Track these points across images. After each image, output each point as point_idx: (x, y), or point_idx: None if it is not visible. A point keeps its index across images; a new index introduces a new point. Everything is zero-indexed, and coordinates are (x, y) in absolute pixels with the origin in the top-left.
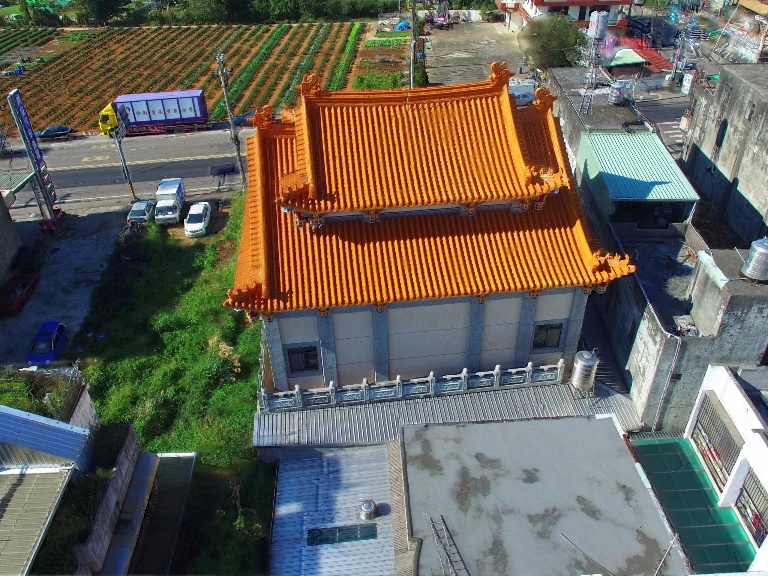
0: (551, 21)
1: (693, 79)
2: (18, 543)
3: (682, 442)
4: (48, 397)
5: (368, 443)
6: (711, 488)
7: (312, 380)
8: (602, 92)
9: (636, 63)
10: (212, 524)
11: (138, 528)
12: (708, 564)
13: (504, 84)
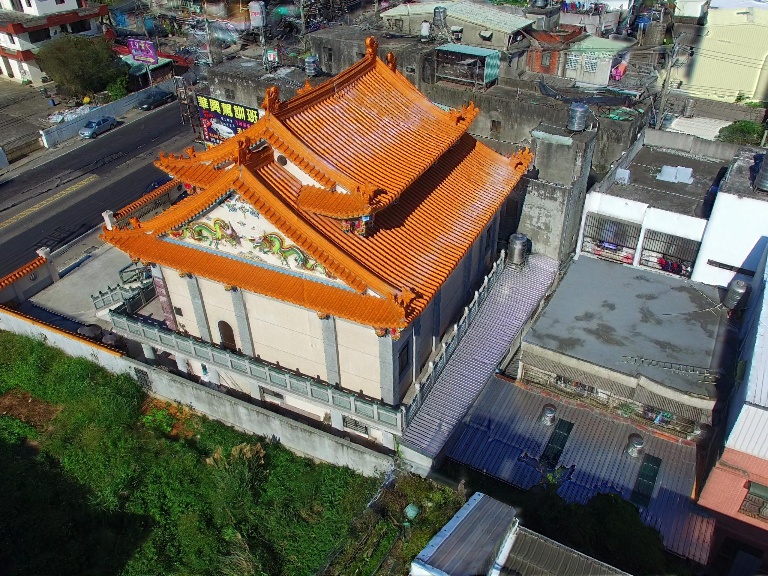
0: (69, 42)
1: (279, 54)
2: None
3: None
4: (463, 481)
5: None
6: None
7: (406, 378)
8: (285, 72)
9: (165, 64)
10: None
11: None
12: None
13: (376, 56)
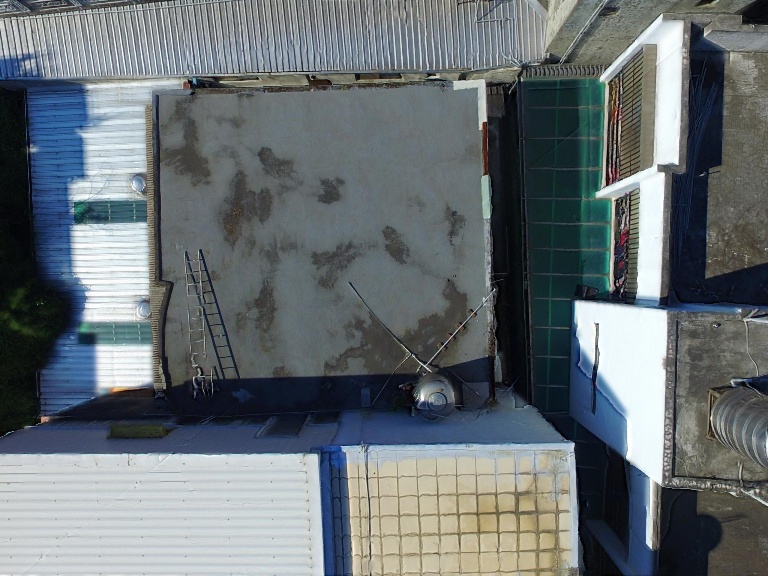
0: None
1: None
2: None
3: (594, 87)
4: None
5: (139, 77)
6: (599, 168)
7: None
8: None
9: None
10: None
11: None
12: (546, 274)
13: None
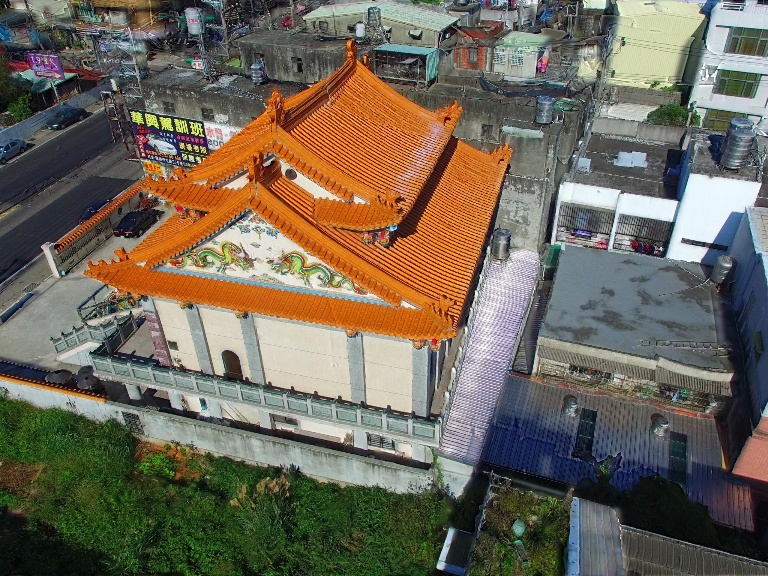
0: None
1: None
2: (723, 570)
3: (556, 247)
4: (572, 489)
5: None
6: None
7: None
8: (228, 81)
9: (70, 78)
10: None
11: None
12: None
13: (356, 59)
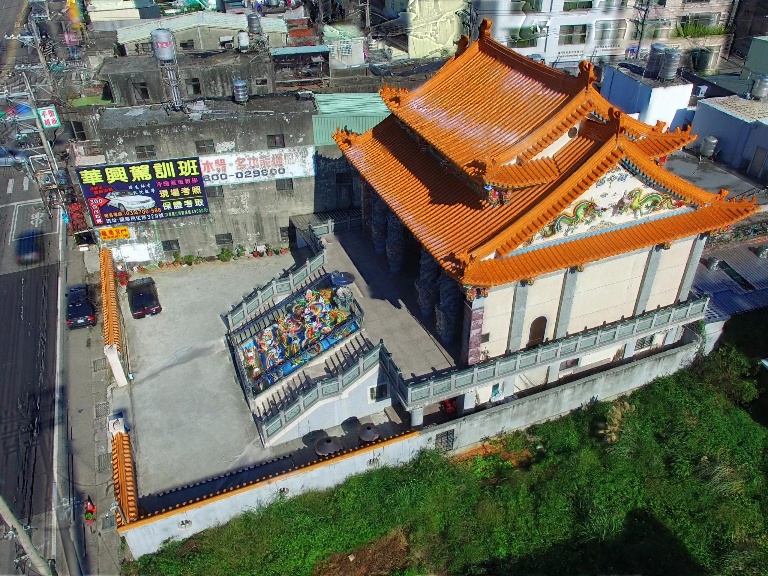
0: None
1: (58, 108)
2: None
3: None
4: None
5: None
6: None
7: None
8: (202, 107)
9: None
10: None
11: None
12: None
13: None
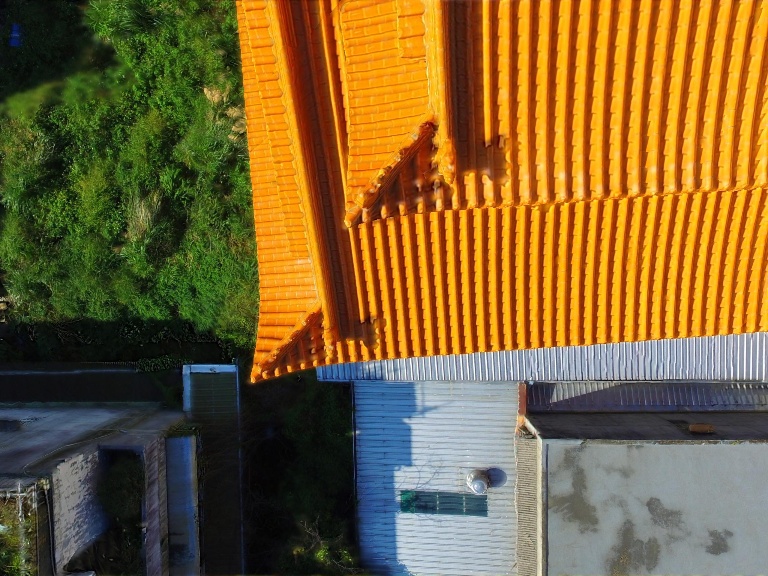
0: None
1: None
2: None
3: None
4: None
5: None
6: None
7: None
8: None
9: None
10: (283, 497)
11: (197, 548)
12: None
13: None
